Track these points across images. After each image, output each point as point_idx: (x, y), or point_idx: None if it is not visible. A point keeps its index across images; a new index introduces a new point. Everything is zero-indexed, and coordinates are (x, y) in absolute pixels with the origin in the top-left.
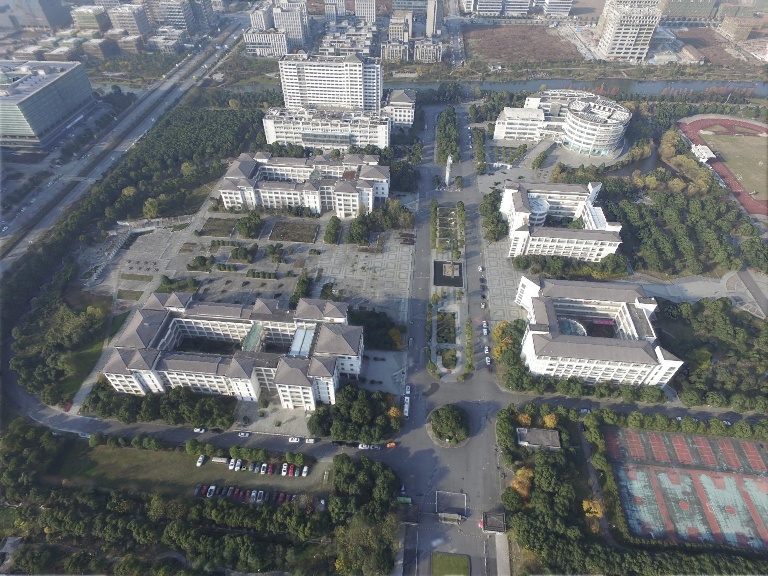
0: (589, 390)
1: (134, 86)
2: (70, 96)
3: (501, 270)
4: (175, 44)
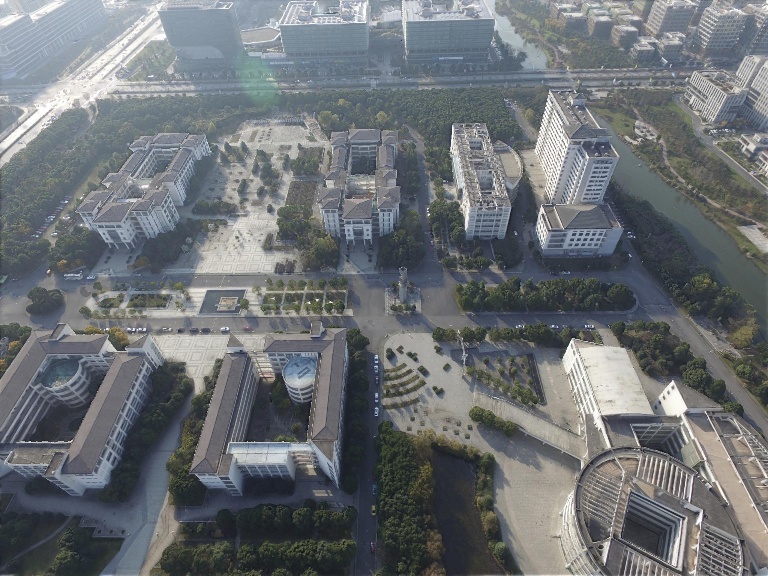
0: None
1: (547, 64)
2: (461, 38)
3: (220, 349)
4: (647, 51)
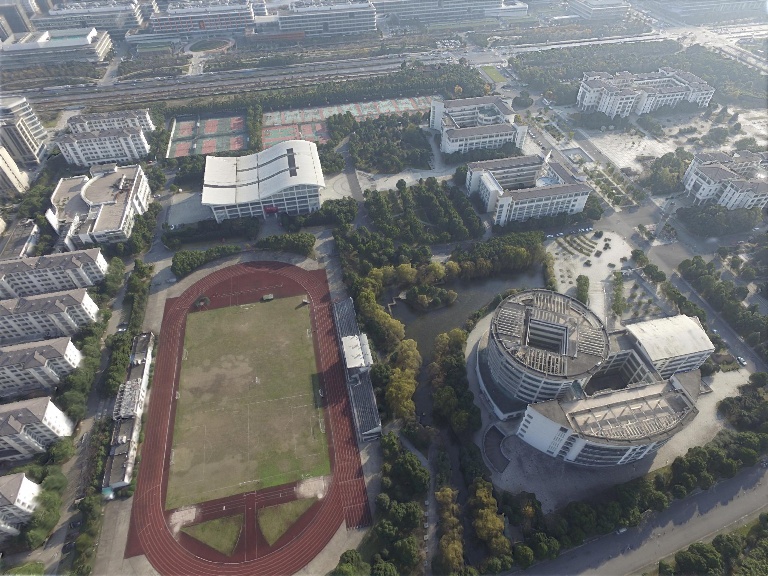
0: None
1: None
2: None
3: None
4: None
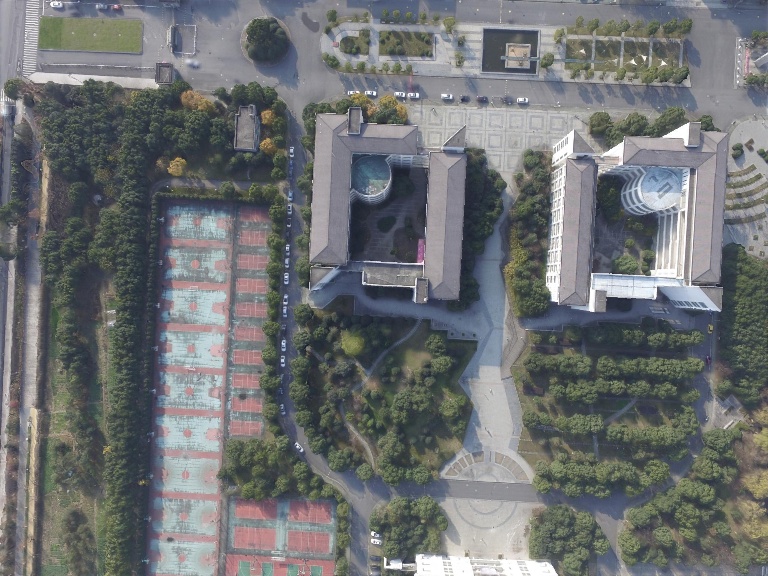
0: (308, 199)
1: None
2: None
3: (522, 132)
4: None
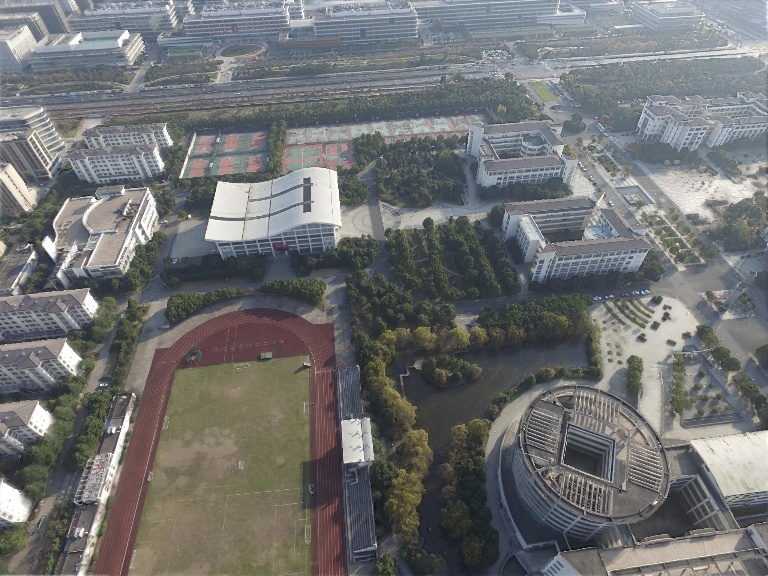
0: None
1: None
2: None
3: None
4: None
